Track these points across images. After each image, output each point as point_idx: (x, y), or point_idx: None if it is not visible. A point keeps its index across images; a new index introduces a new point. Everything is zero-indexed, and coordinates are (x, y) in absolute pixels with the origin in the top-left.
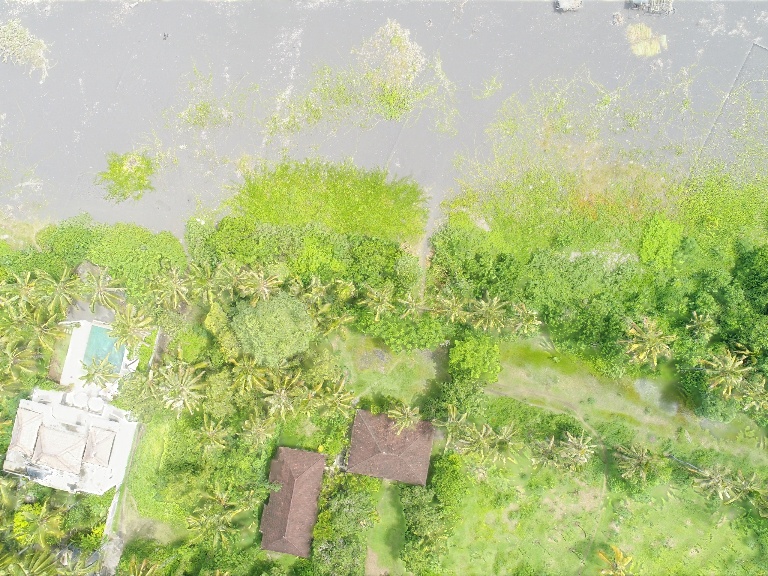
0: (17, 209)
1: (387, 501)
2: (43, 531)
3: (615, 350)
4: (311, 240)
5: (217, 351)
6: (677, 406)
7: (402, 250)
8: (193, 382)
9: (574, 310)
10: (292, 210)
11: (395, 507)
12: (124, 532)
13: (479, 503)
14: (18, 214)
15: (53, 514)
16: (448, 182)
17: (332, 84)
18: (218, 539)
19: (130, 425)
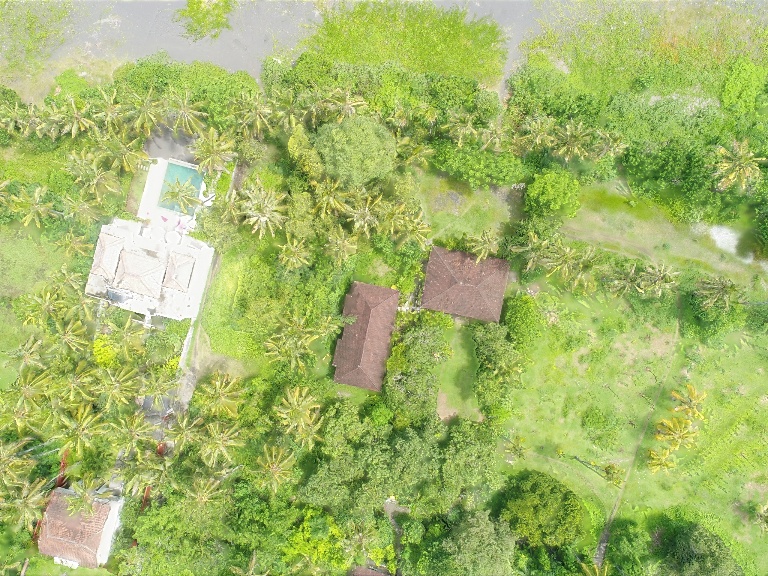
0: (95, 46)
1: (458, 343)
2: (128, 344)
3: (698, 184)
4: (389, 77)
5: (297, 178)
6: (754, 253)
7: (480, 89)
8: (275, 204)
9: (656, 146)
10: (369, 49)
11: (466, 349)
12: (197, 368)
13: (550, 346)
14: (96, 52)
15: (136, 331)
16: (528, 22)
17: None
18: (295, 364)
19: (206, 259)
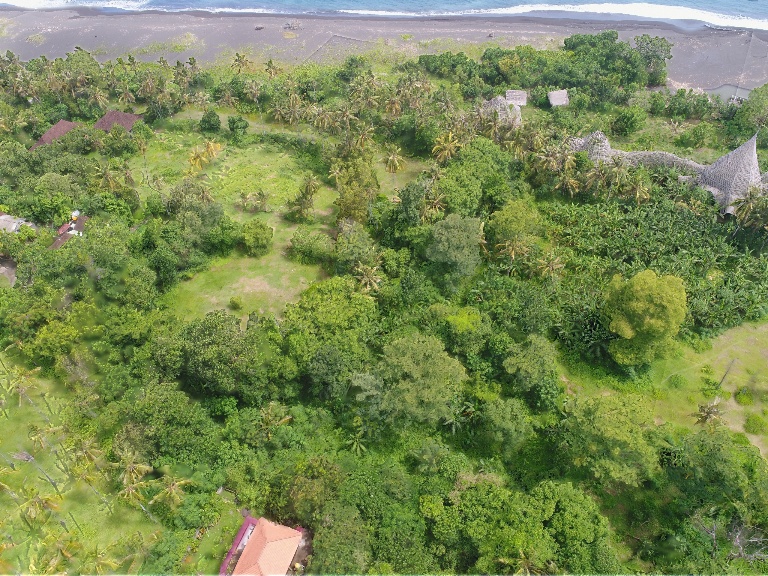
0: None
1: None
2: None
3: None
4: None
5: None
6: (274, 122)
7: None
8: None
9: None
10: None
11: None
12: None
13: None
14: None
15: None
16: None
17: (156, 45)
18: (8, 131)
19: None
